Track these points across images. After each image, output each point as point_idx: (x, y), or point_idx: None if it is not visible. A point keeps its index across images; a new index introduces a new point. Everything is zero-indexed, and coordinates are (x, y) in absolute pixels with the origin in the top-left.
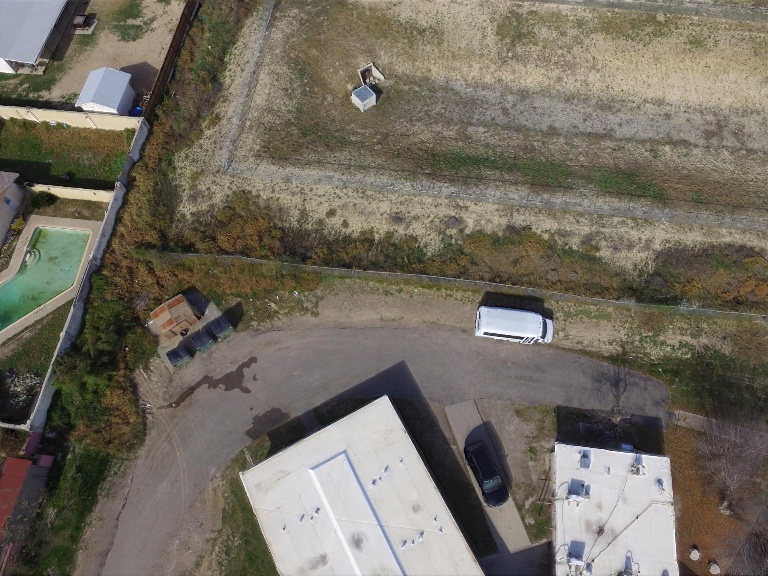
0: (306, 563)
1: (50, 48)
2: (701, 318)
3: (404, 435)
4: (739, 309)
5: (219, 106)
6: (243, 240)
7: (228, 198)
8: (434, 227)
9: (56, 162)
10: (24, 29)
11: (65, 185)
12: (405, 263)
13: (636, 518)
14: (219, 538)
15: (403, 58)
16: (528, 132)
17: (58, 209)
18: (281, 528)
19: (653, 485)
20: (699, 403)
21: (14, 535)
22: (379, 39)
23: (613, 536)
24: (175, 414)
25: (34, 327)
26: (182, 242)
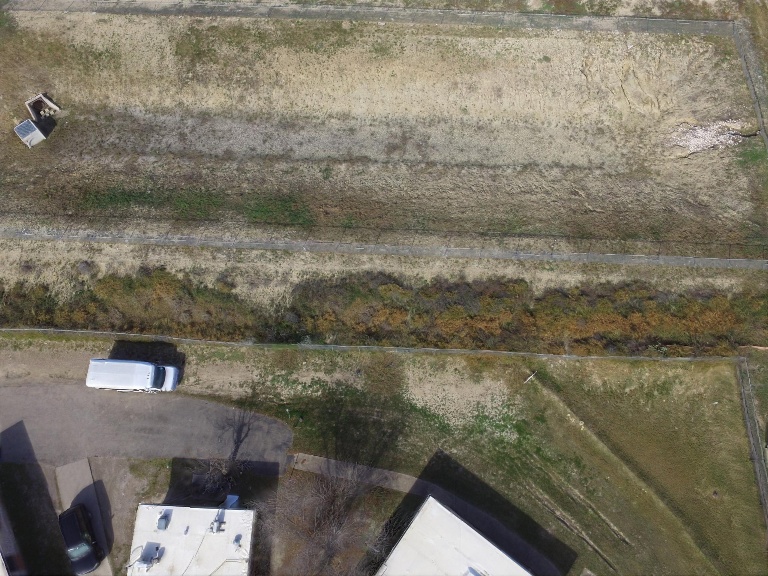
0: None
1: None
2: (335, 352)
3: None
4: (366, 341)
5: None
6: None
7: None
8: (66, 274)
9: None
10: None
11: None
12: (31, 315)
13: None
14: None
15: (79, 86)
16: (201, 159)
17: None
18: None
19: (230, 542)
20: (321, 443)
21: None
22: (53, 67)
23: None
24: None
25: None
26: None
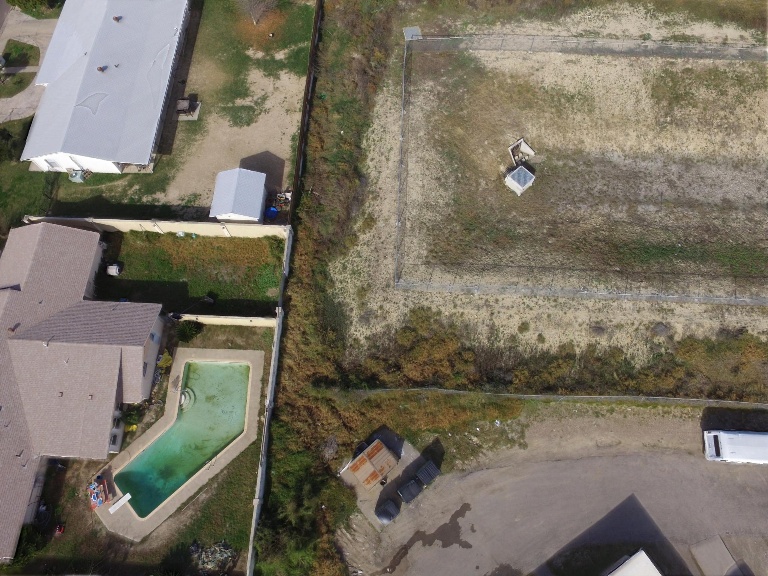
0: None
1: (156, 141)
2: None
3: None
4: None
5: (370, 204)
6: (431, 366)
7: (406, 317)
8: (640, 336)
9: (192, 281)
10: (127, 123)
11: (216, 313)
12: (615, 380)
13: None
14: None
15: (552, 129)
16: (703, 208)
17: (206, 339)
18: None
19: None
20: None
21: None
22: (524, 110)
23: None
24: None
25: (209, 487)
26: (363, 373)
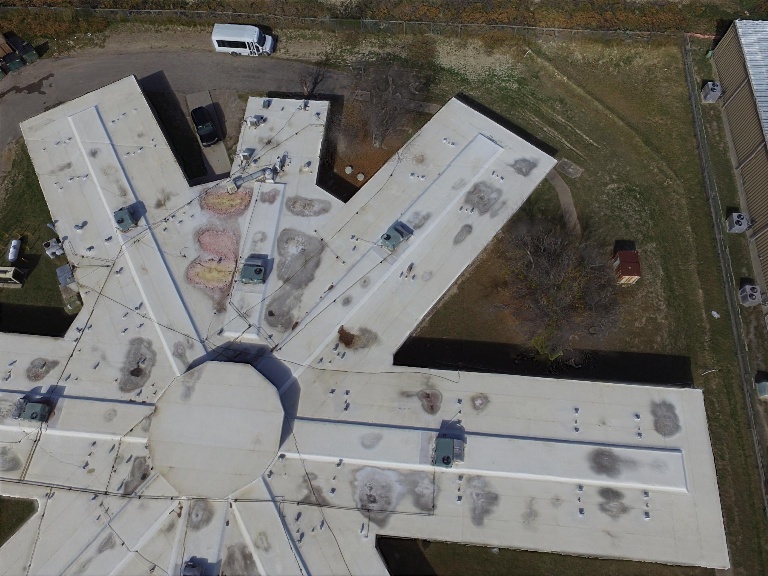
0: (56, 167)
1: None
2: (387, 35)
3: (140, 96)
4: None
5: None
6: None
7: None
8: None
9: None
10: None
11: None
12: None
13: (295, 134)
14: (8, 176)
15: None
16: None
17: None
18: (42, 149)
19: (312, 116)
20: (375, 86)
21: None
22: None
23: (277, 144)
24: None
25: None
26: (7, 3)
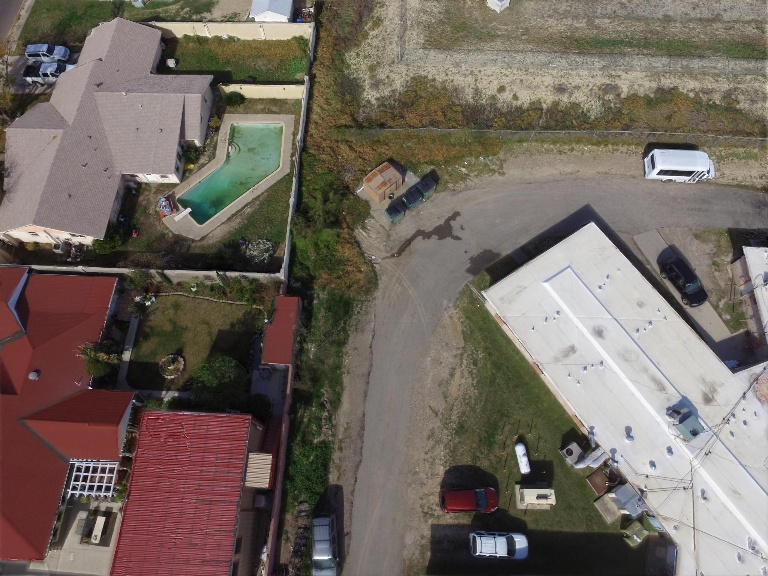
0: (558, 353)
1: None
2: None
3: (616, 251)
4: None
5: (378, 11)
6: (428, 117)
7: (407, 83)
8: (594, 94)
9: (235, 69)
10: None
11: None
12: (574, 125)
13: None
14: (464, 353)
15: None
16: (648, 20)
17: (248, 107)
18: (530, 329)
19: None
20: None
21: (293, 359)
22: None
23: None
24: (399, 262)
25: (253, 203)
26: (374, 122)
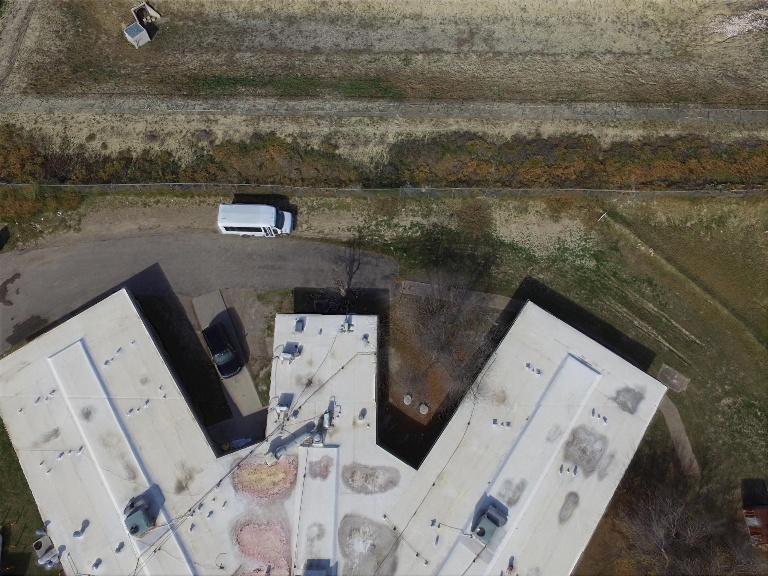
0: (39, 438)
1: None
2: (430, 199)
3: (137, 320)
4: (459, 186)
5: None
6: (7, 169)
7: None
8: (187, 141)
9: None
10: None
11: None
12: (159, 176)
13: (341, 368)
14: None
15: None
16: (292, 53)
17: None
18: (18, 411)
19: (359, 339)
20: (424, 273)
21: None
22: None
23: (320, 385)
24: None
25: None
26: None
